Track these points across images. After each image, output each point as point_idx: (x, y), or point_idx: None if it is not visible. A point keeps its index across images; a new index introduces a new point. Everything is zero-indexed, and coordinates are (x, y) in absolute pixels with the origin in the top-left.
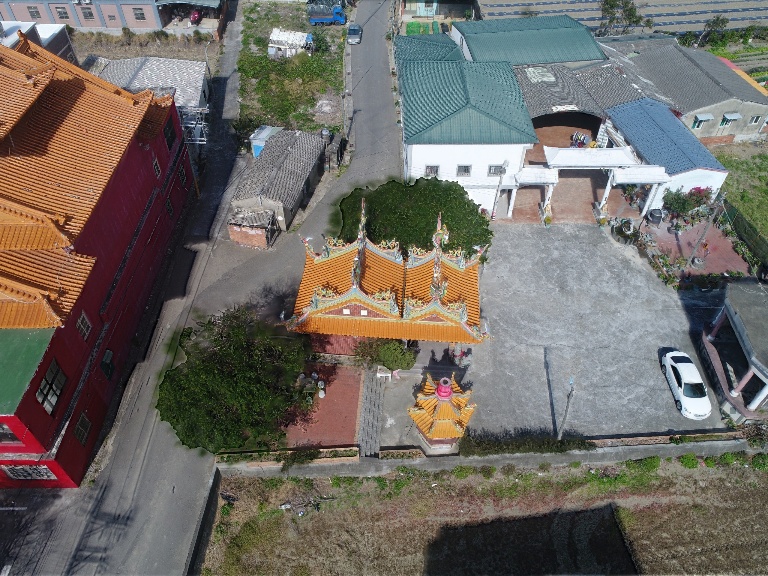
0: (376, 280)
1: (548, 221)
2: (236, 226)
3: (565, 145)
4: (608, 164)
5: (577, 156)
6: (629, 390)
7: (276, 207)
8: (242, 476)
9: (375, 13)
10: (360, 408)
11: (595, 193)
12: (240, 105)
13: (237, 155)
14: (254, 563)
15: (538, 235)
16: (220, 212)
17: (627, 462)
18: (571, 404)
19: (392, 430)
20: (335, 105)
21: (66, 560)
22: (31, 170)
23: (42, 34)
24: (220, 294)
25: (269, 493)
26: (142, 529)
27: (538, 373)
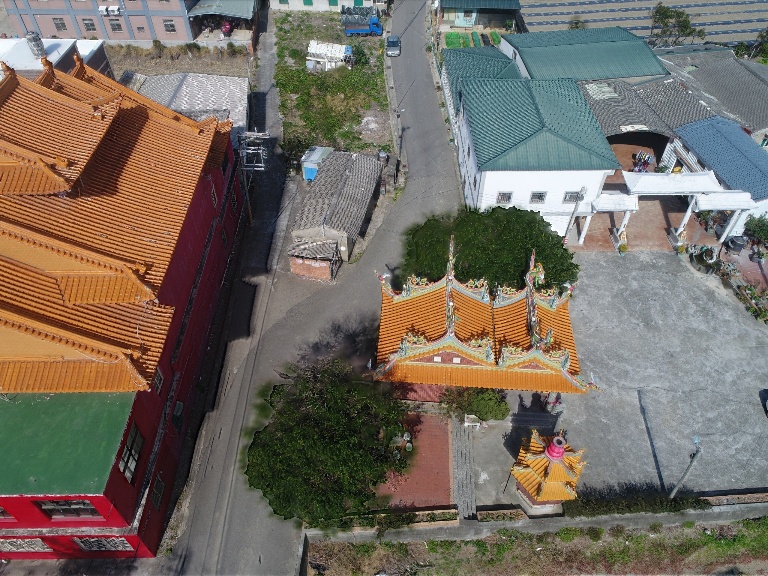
0: (466, 323)
1: (624, 249)
2: (299, 258)
3: (628, 165)
4: (694, 191)
5: (660, 182)
6: (735, 438)
7: (340, 237)
8: (331, 542)
9: (411, 23)
10: (452, 463)
11: (667, 217)
12: (282, 122)
13: (286, 177)
14: None
15: (613, 264)
16: (276, 241)
17: (744, 521)
18: (675, 455)
19: (487, 486)
20: (382, 122)
21: None
22: (103, 212)
23: (79, 50)
24: (287, 333)
25: (361, 560)
26: None
27: (635, 420)
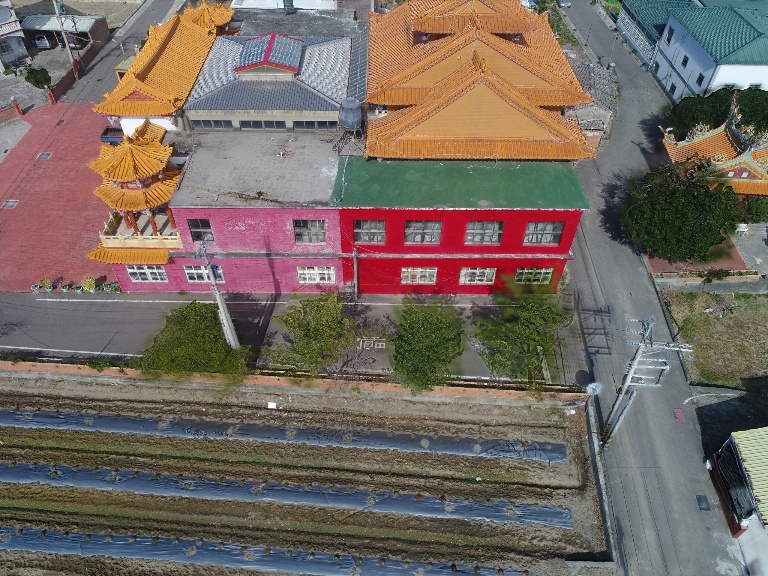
0: None
1: None
2: None
3: None
4: None
5: None
6: None
7: (604, 116)
8: (670, 290)
9: None
10: (738, 249)
11: None
12: None
13: None
14: (704, 343)
15: None
16: None
17: None
18: None
19: (763, 265)
20: (578, 53)
21: (578, 334)
22: None
23: None
24: (584, 177)
25: (691, 302)
26: (624, 316)
27: None
